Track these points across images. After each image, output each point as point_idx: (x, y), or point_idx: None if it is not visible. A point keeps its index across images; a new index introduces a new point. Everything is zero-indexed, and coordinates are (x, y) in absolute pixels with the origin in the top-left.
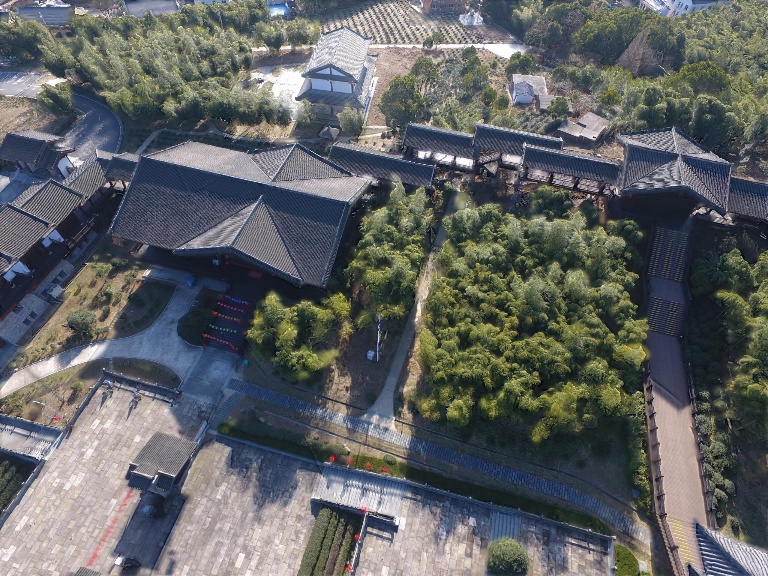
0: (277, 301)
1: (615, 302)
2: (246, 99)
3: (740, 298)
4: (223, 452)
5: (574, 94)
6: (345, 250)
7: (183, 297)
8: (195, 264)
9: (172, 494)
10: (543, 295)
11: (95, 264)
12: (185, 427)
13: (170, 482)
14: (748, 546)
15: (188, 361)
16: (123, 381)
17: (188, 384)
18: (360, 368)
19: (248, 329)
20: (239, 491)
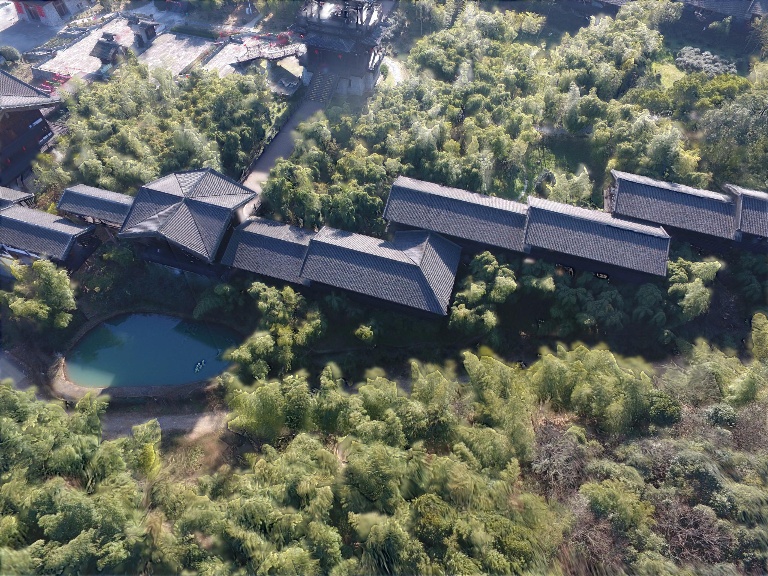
0: None
1: None
2: None
3: None
4: (172, 36)
5: None
6: None
7: None
8: None
9: (147, 43)
10: None
11: None
12: None
13: (146, 26)
14: (392, 50)
15: (159, 15)
16: (126, 18)
17: (158, 20)
18: (242, 16)
19: (189, 2)
20: (178, 44)
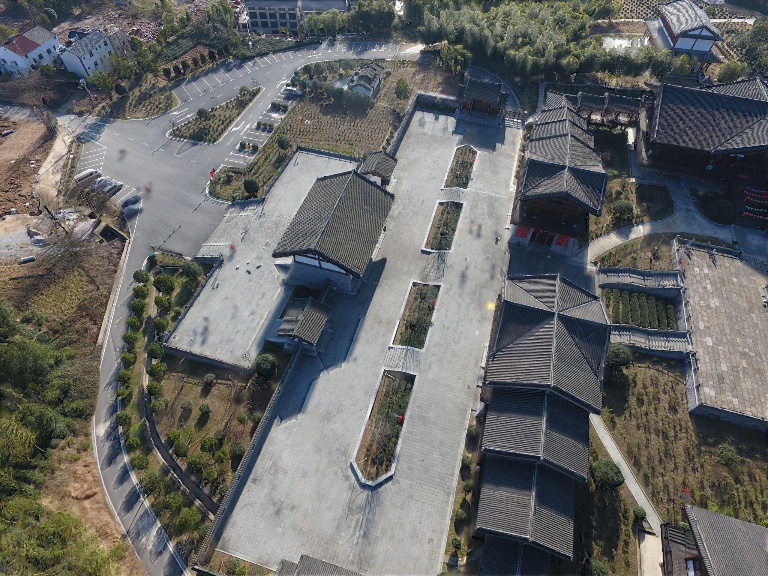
0: None
1: None
2: (635, 54)
3: None
4: None
5: None
6: None
7: (680, 195)
8: None
9: None
10: None
11: None
12: (763, 274)
13: None
14: None
15: (727, 234)
16: (692, 245)
17: None
18: None
19: (767, 212)
20: None
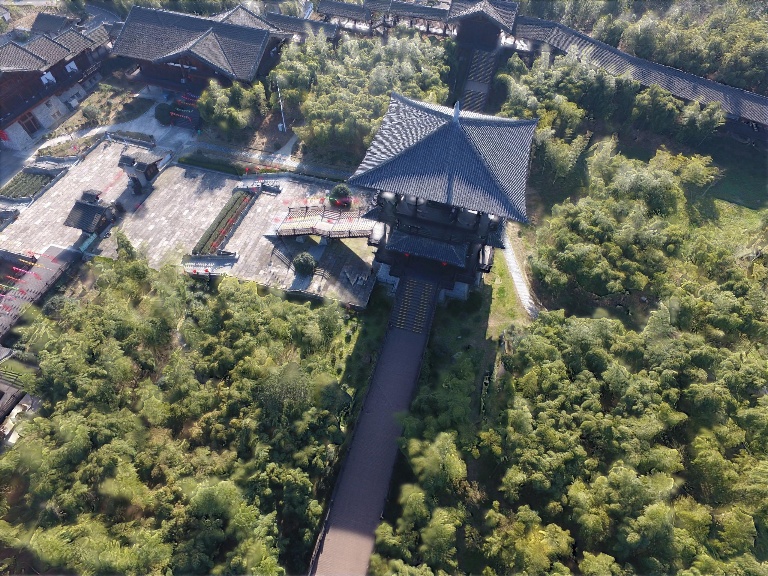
0: (218, 86)
1: (430, 78)
2: None
3: (510, 76)
4: (180, 171)
5: None
6: (269, 69)
7: None
8: (168, 80)
9: (147, 186)
10: (387, 78)
11: (101, 92)
12: None
13: (144, 167)
14: None
15: (161, 132)
16: (118, 139)
17: (160, 142)
18: (273, 135)
19: None
20: (188, 186)
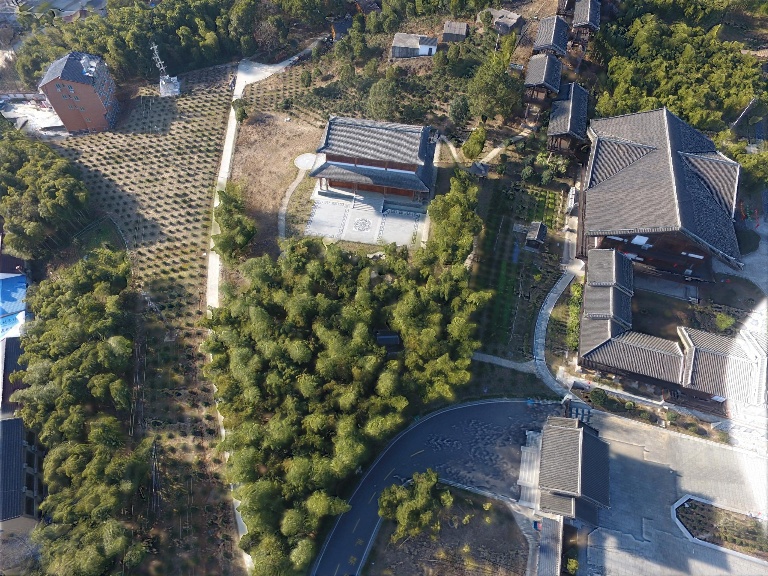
0: None
1: None
2: None
3: None
4: None
5: (437, 20)
6: None
7: None
8: None
9: None
10: None
11: None
12: None
13: None
14: None
15: (767, 247)
16: None
17: None
18: None
19: None
20: None
